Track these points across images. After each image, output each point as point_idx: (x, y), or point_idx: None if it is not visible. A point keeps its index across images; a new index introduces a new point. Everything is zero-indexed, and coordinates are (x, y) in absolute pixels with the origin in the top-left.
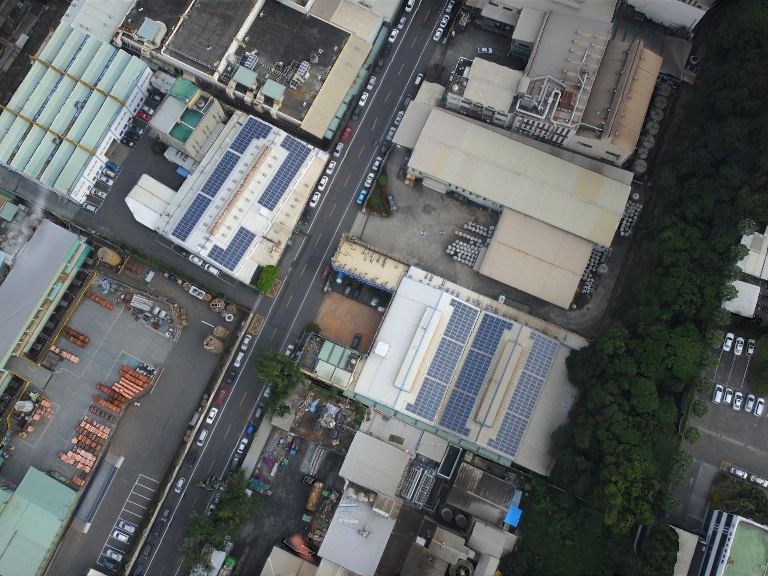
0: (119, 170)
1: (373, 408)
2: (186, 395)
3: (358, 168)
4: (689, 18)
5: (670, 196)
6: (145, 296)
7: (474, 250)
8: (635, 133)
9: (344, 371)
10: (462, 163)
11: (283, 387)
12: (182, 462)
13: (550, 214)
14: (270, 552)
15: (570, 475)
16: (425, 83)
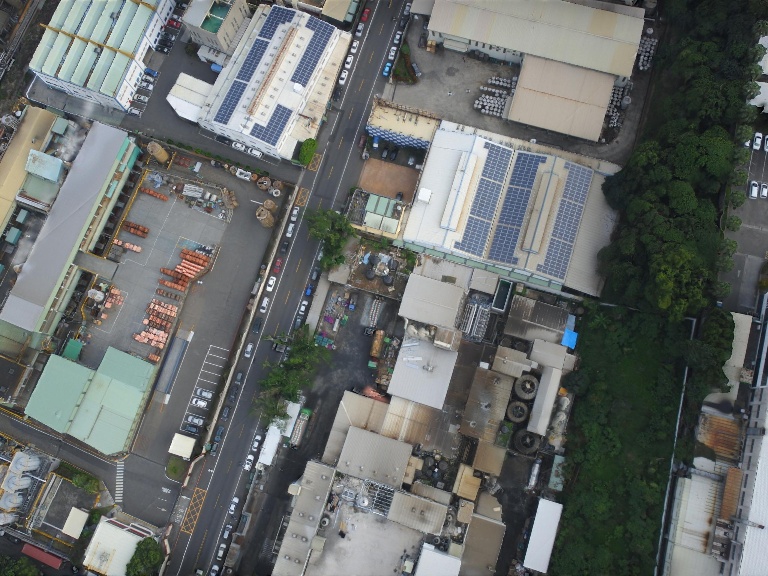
0: (157, 75)
1: (423, 254)
2: (244, 269)
3: (380, 44)
4: None
5: (683, 22)
6: (195, 184)
7: (500, 101)
8: None
9: (391, 219)
10: (479, 19)
11: (336, 242)
12: (248, 329)
13: (569, 54)
14: (342, 397)
15: (620, 283)
16: None
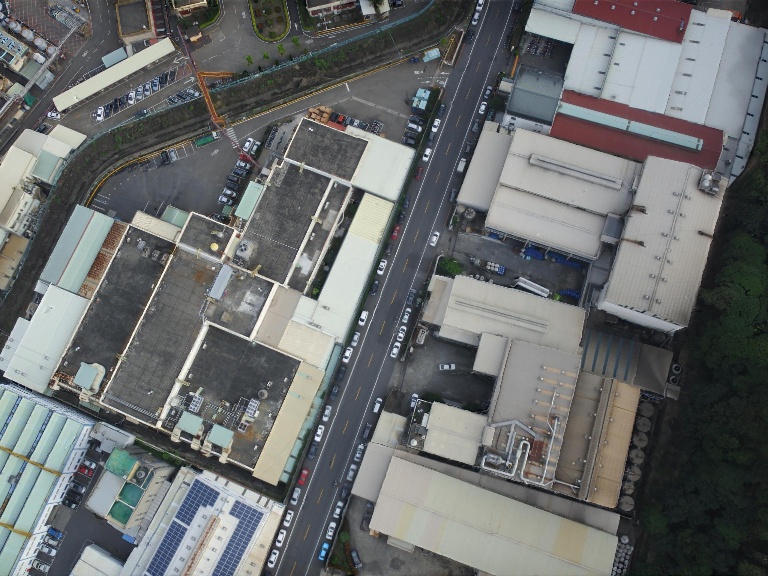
0: (62, 536)
1: None
2: None
3: (318, 516)
4: (666, 327)
5: (662, 549)
6: None
7: None
8: (616, 483)
9: None
10: (428, 523)
11: None
12: None
13: None
14: None
15: None
16: (384, 413)
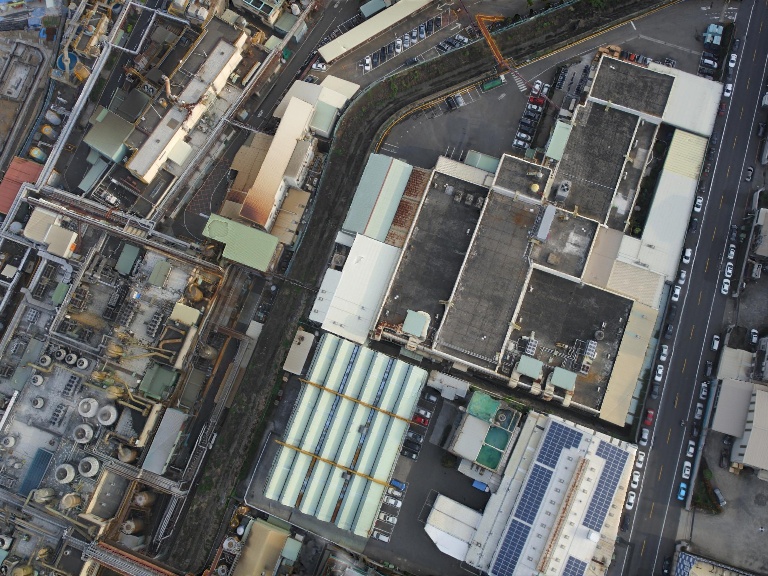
0: (405, 487)
1: None
2: None
3: (670, 456)
4: None
5: None
6: None
7: None
8: None
9: None
10: None
11: None
12: None
13: None
14: None
15: None
16: (727, 349)
